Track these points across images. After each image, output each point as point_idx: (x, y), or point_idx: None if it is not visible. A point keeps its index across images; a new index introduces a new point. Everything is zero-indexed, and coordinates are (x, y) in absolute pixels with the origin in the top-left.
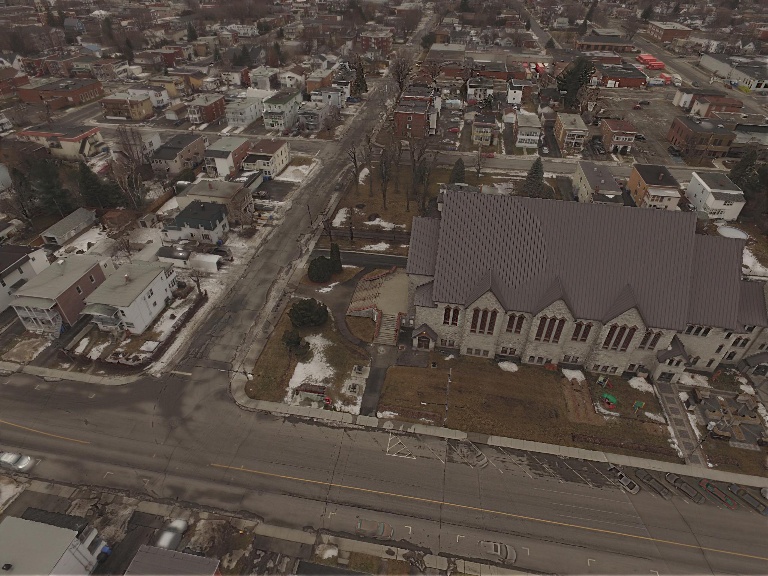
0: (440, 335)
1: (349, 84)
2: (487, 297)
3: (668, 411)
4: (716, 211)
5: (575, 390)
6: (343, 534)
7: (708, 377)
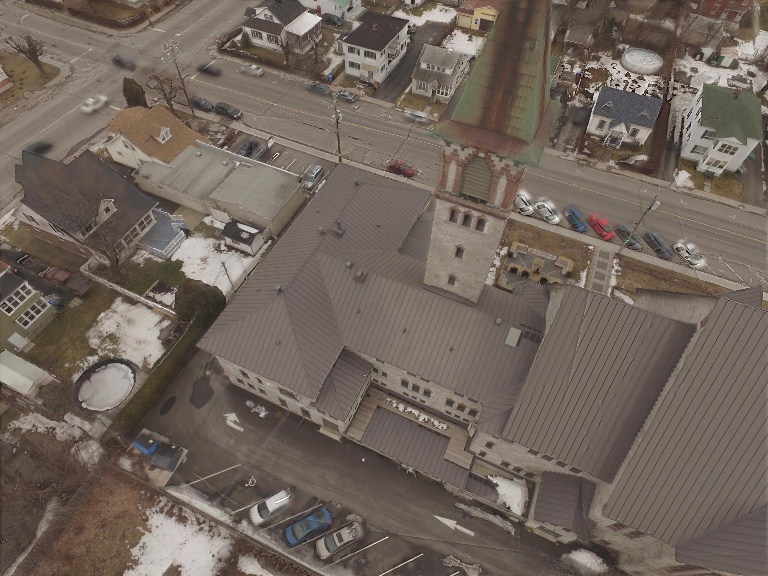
0: None
1: None
2: None
3: None
4: None
5: None
6: None
7: None
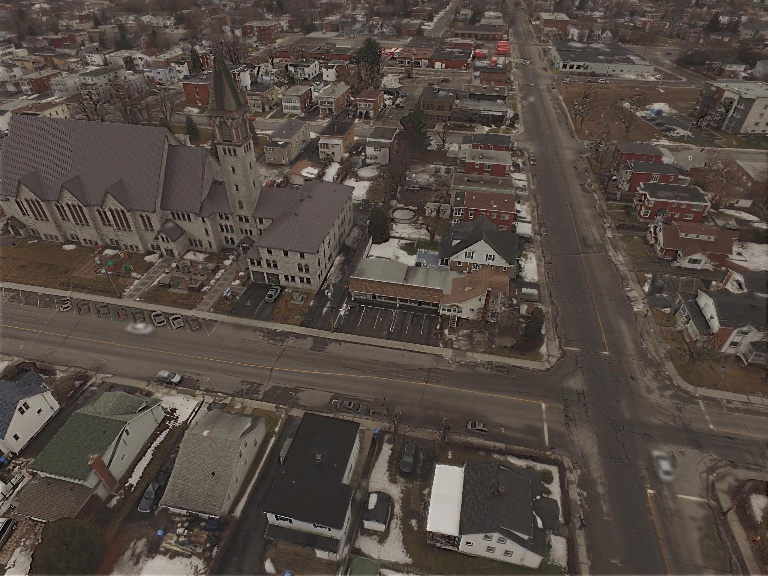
0: (27, 225)
1: (186, 63)
2: (25, 189)
3: (150, 272)
4: (372, 156)
5: None
6: None
7: None
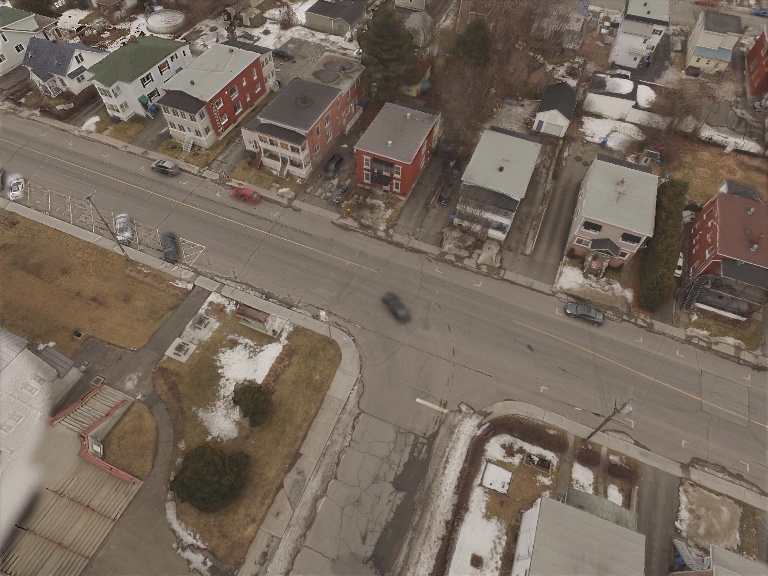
0: None
1: None
2: None
3: None
4: None
5: None
6: (271, 201)
7: None
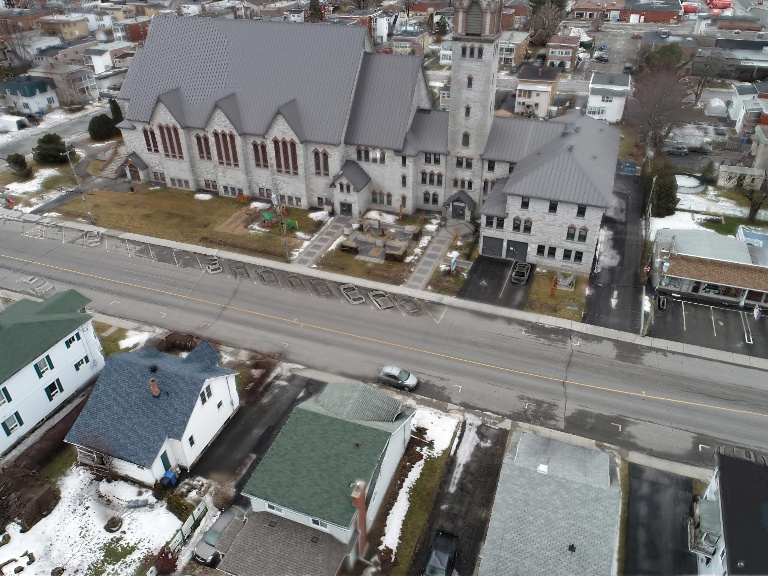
0: (150, 166)
1: (303, 12)
2: (163, 110)
3: (322, 233)
4: (596, 110)
5: (246, 214)
6: None
7: None
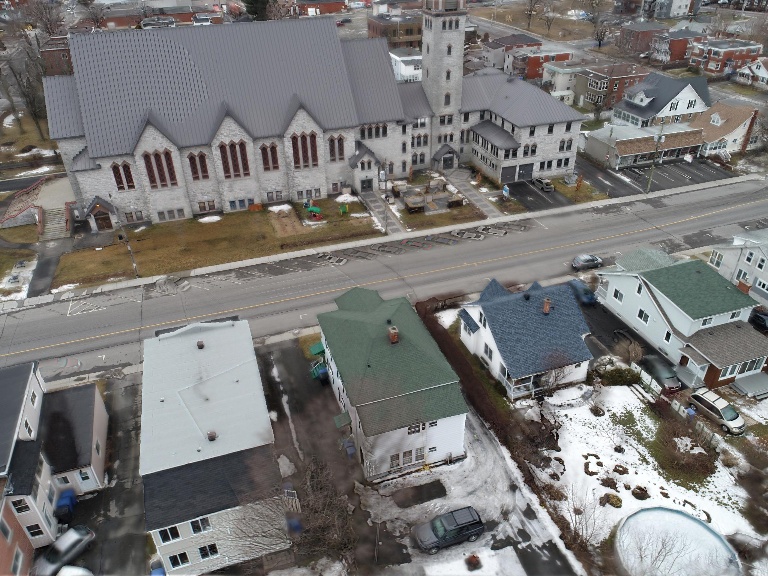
0: (121, 208)
1: None
2: (150, 135)
3: (372, 208)
4: (411, 78)
5: (282, 217)
6: None
7: (407, 180)
